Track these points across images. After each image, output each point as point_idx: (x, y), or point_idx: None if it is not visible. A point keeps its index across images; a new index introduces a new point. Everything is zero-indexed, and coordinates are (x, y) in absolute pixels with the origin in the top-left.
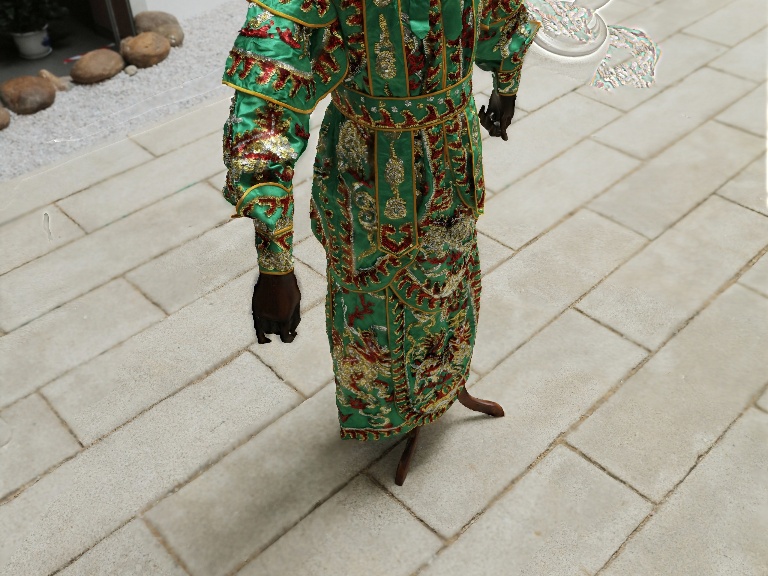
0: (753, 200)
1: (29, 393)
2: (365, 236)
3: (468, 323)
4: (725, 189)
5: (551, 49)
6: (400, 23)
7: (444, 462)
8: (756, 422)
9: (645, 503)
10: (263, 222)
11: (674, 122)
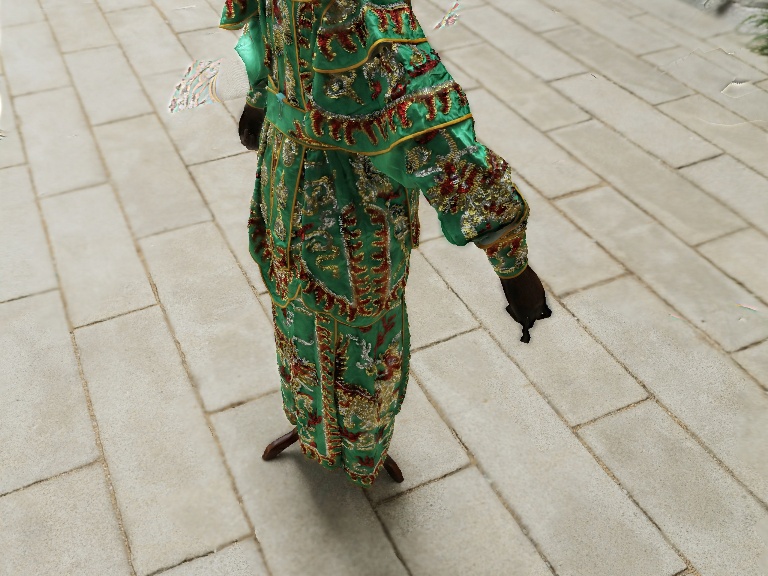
0: (213, 152)
1: None
2: (399, 248)
3: None
4: (188, 159)
5: None
6: None
7: (391, 439)
8: (432, 249)
9: (479, 331)
10: None
11: (74, 145)
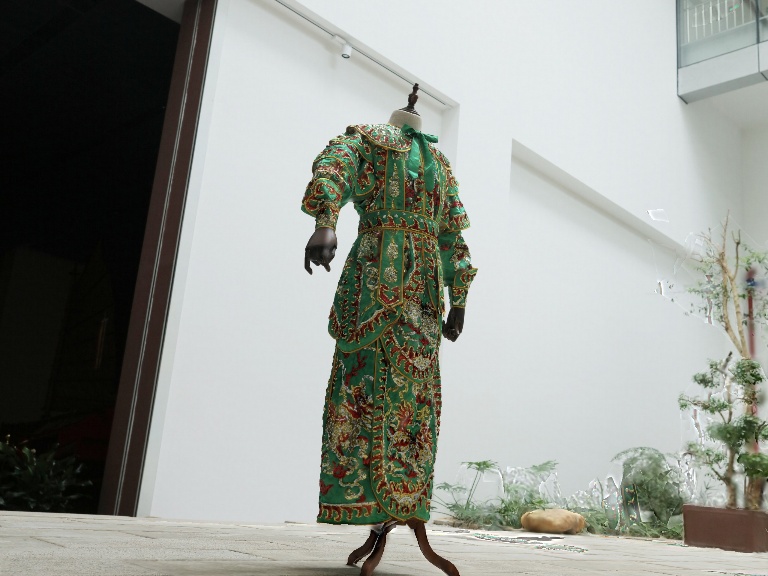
0: (674, 573)
1: (23, 536)
2: (369, 295)
3: (431, 433)
4: None
5: (496, 540)
6: (404, 170)
7: None
8: None
9: None
10: (326, 195)
11: None
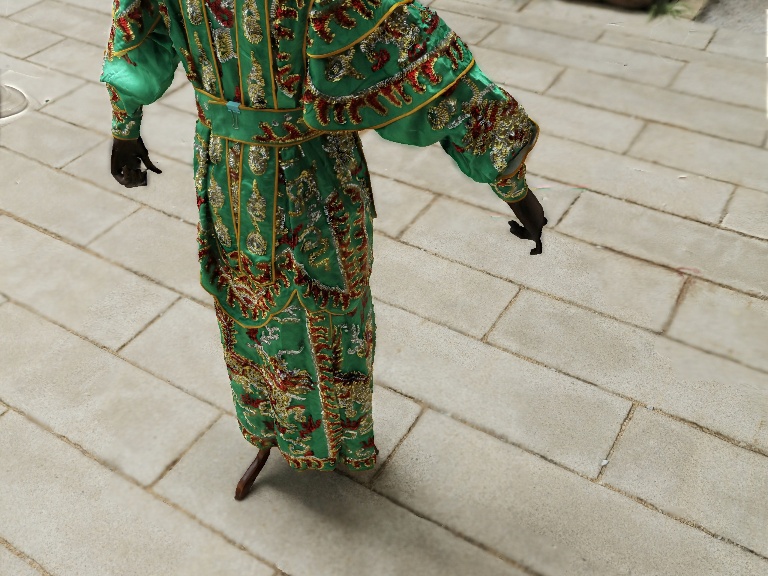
0: None
1: None
2: None
3: None
4: None
5: None
6: None
7: None
8: None
9: None
10: None
11: None
